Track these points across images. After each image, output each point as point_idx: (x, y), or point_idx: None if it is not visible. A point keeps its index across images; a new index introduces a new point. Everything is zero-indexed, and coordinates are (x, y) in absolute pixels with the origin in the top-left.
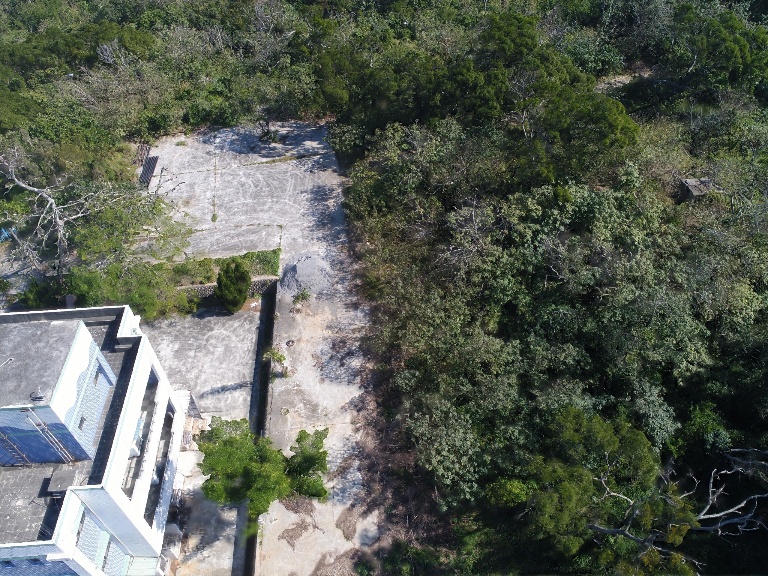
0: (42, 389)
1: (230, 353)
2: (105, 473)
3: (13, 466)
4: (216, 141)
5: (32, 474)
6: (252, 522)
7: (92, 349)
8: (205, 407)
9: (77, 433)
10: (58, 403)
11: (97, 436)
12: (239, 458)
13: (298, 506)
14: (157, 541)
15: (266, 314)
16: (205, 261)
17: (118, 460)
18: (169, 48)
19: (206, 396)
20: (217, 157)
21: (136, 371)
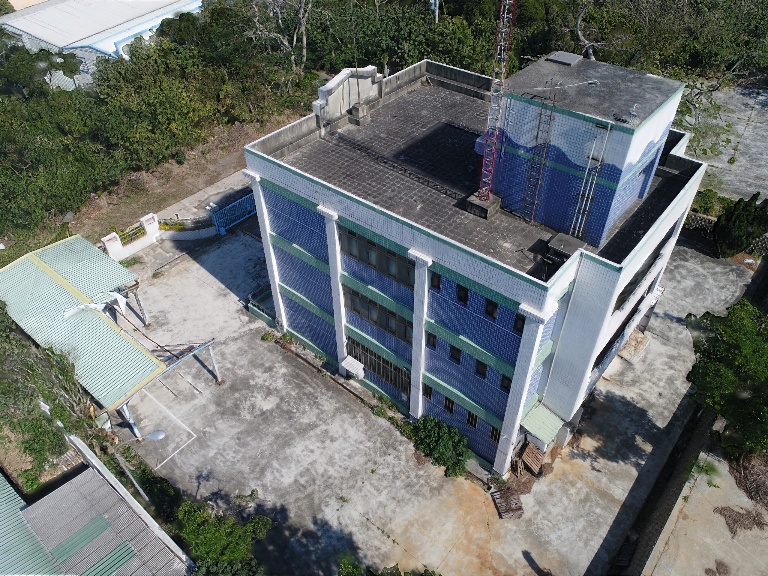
0: (629, 115)
1: (701, 292)
2: (628, 257)
3: (511, 213)
4: (758, 97)
5: (528, 229)
6: (666, 473)
7: (666, 130)
8: (650, 326)
9: (615, 200)
10: (635, 141)
11: (610, 232)
12: (767, 361)
13: (757, 492)
14: (578, 402)
15: (763, 277)
16: (708, 192)
17: (636, 260)
18: (732, 8)
19: (655, 317)
20: (755, 111)
21: (687, 190)
